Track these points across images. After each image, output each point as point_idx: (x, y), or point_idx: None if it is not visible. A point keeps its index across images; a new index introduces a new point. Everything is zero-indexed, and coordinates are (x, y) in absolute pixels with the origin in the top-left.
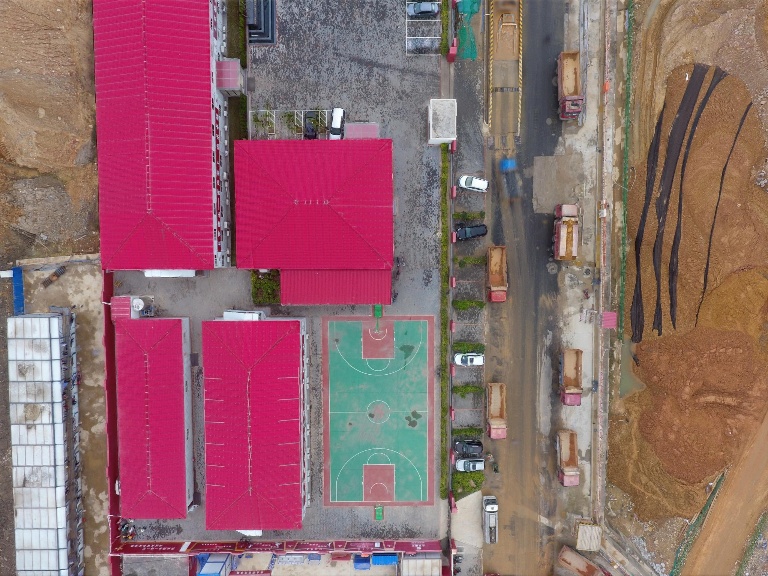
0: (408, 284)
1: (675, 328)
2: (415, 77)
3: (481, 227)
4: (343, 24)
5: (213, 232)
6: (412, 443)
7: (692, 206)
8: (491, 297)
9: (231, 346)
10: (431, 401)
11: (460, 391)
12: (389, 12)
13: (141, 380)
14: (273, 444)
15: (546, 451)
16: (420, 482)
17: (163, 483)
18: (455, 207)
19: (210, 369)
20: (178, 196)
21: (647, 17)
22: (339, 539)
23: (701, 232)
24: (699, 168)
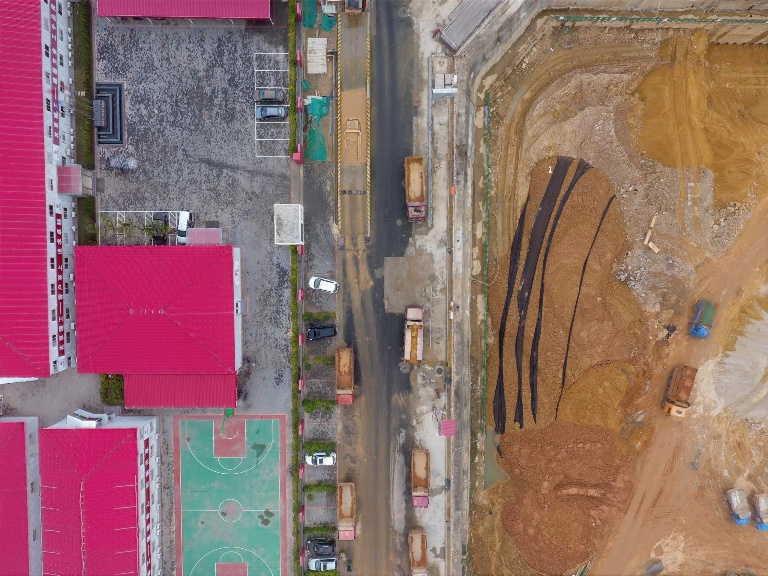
0: (259, 383)
1: (536, 421)
2: (265, 178)
3: (329, 329)
4: (192, 126)
5: (49, 340)
6: (265, 542)
7: (552, 300)
8: (337, 400)
9: (66, 455)
10: (283, 500)
11: (311, 490)
12: (238, 114)
13: None
14: (109, 553)
15: (401, 548)
16: None
17: None
18: (306, 307)
19: (46, 477)
20: (10, 306)
21: (510, 111)
22: None
23: (561, 326)
24: (560, 261)
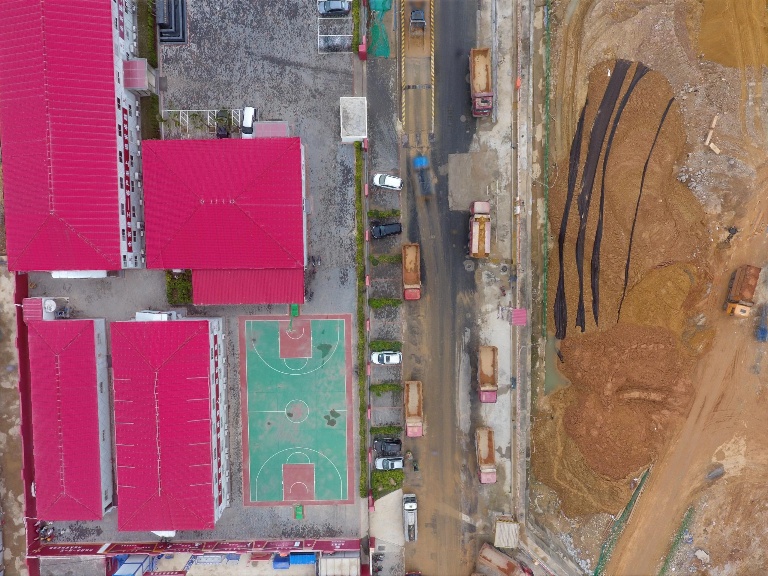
0: (324, 283)
1: (598, 324)
2: (328, 75)
3: (395, 225)
4: (254, 23)
5: (120, 232)
6: (331, 442)
7: (613, 202)
8: (405, 295)
9: (139, 347)
10: (349, 400)
11: (378, 389)
12: (300, 10)
13: (53, 382)
14: (183, 444)
15: (466, 449)
16: (340, 481)
17: (77, 485)
18: (370, 205)
19: (119, 370)
20: (82, 197)
21: (568, 13)
22: (260, 539)
23: (622, 228)
24: (621, 164)
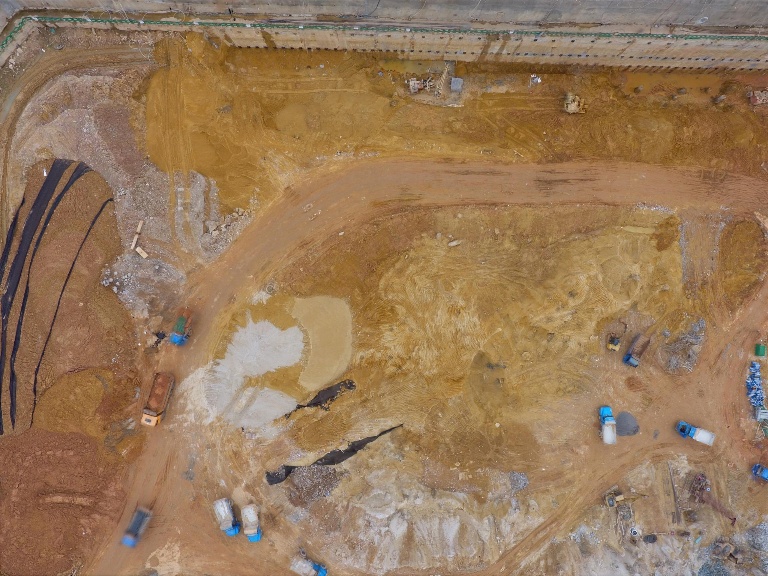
0: None
1: (14, 428)
2: None
3: None
4: None
5: None
6: None
7: (34, 304)
8: None
9: None
10: None
11: None
12: None
13: None
14: None
15: None
16: None
17: None
18: None
19: None
20: None
21: (4, 112)
22: None
23: (40, 331)
24: (47, 266)
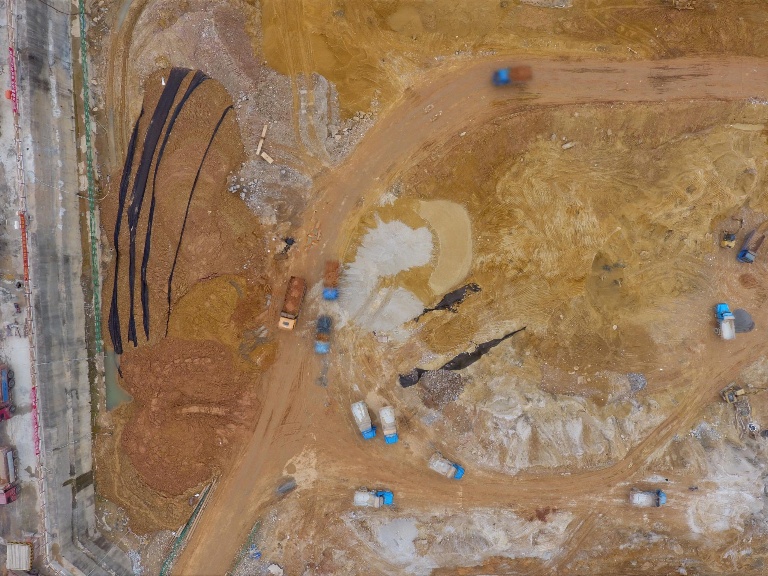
0: None
1: (148, 339)
2: None
3: None
4: None
5: None
6: None
7: (162, 214)
8: None
9: None
10: None
11: None
12: None
13: None
14: None
15: None
16: None
17: None
18: None
19: None
20: None
21: (119, 21)
22: None
23: (170, 240)
24: (172, 175)
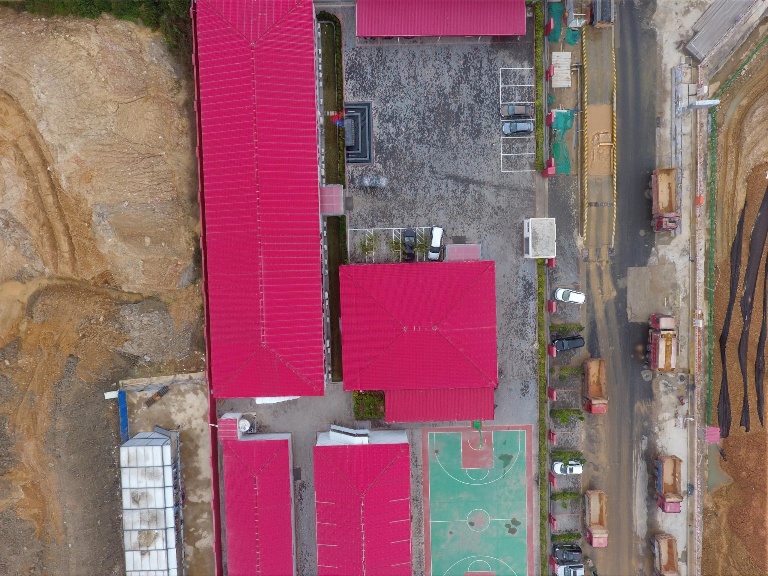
0: (506, 395)
1: (763, 425)
2: (510, 193)
3: (579, 340)
4: (439, 143)
5: (323, 359)
6: (512, 550)
7: None
8: (591, 410)
9: (343, 471)
10: (530, 508)
11: (559, 498)
12: (484, 130)
13: (250, 502)
14: (386, 566)
15: (643, 553)
16: None
17: None
18: (551, 318)
19: (322, 493)
20: (290, 327)
21: (727, 117)
22: None
23: None
24: None
